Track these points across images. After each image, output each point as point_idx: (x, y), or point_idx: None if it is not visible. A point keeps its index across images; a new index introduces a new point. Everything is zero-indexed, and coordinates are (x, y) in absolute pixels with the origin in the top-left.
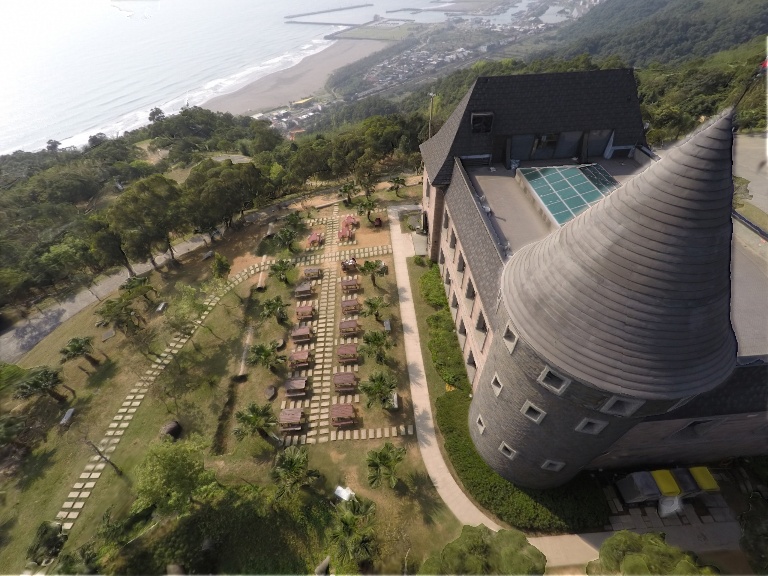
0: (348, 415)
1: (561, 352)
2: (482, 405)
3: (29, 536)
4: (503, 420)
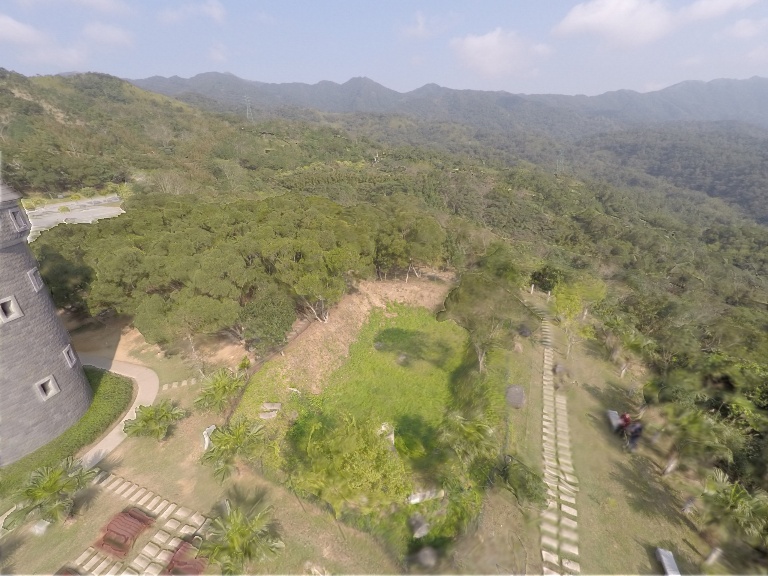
0: (125, 513)
1: (1, 190)
2: (27, 369)
3: (609, 570)
4: (45, 327)
